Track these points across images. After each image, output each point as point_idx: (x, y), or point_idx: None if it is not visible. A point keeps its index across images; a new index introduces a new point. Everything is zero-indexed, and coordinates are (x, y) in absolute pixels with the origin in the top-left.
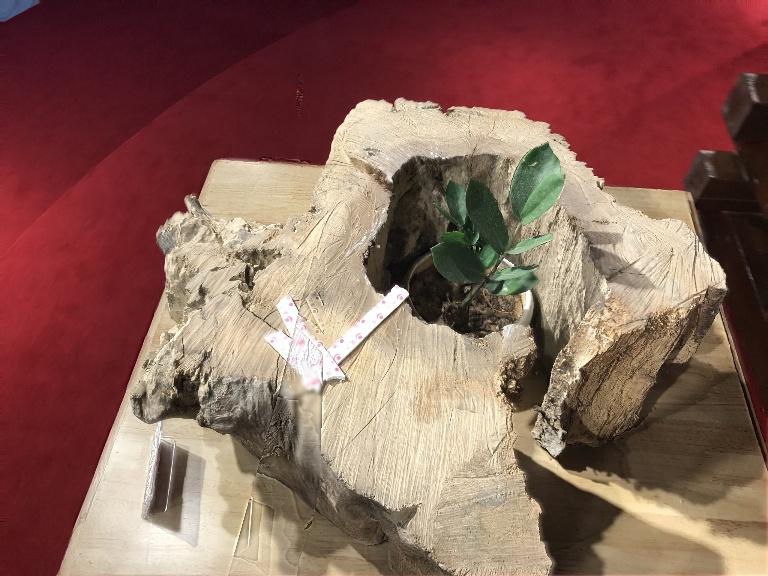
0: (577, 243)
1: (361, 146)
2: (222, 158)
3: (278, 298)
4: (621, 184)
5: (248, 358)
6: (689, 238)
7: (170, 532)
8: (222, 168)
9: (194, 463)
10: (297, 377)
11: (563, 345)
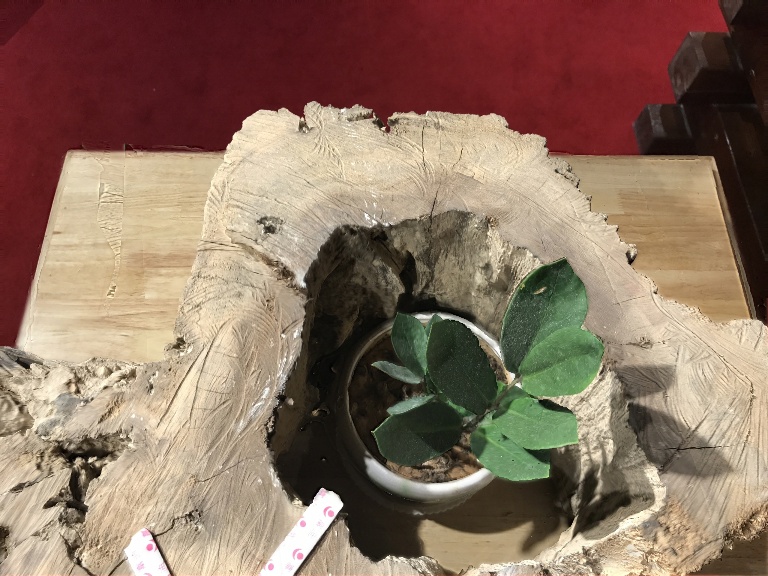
0: (603, 379)
1: (251, 215)
2: (79, 147)
3: (128, 532)
4: (625, 151)
5: None
6: None
7: None
8: (78, 167)
9: None
10: None
11: (569, 459)
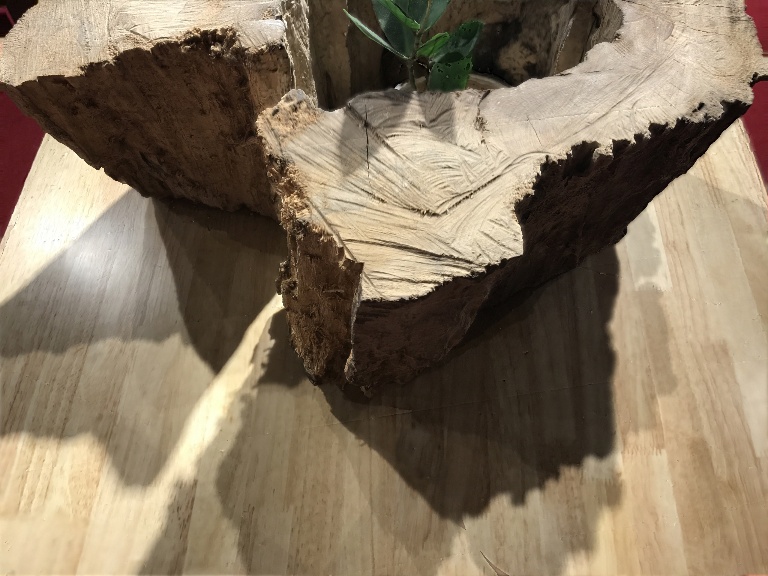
0: None
1: None
2: None
3: None
4: None
5: None
6: (469, 248)
7: None
8: None
9: None
10: None
11: None
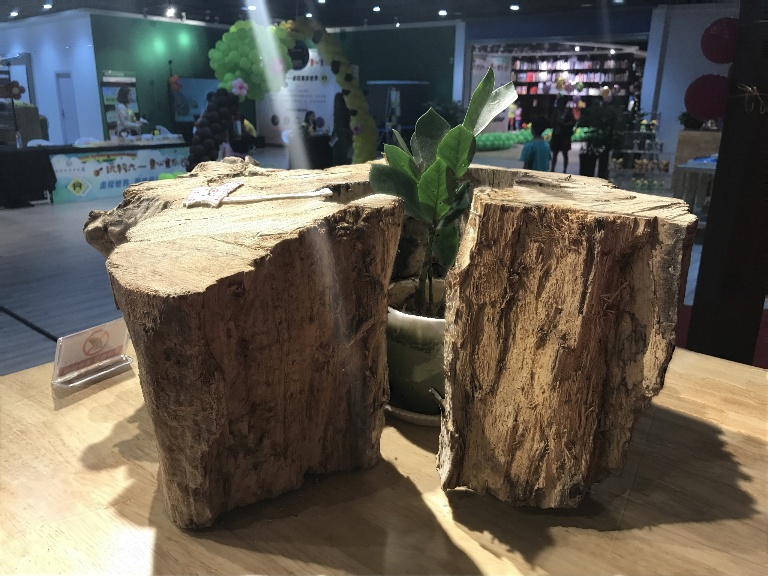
0: None
1: None
2: None
3: None
4: None
5: (172, 193)
6: (670, 199)
7: (54, 396)
8: None
9: (126, 375)
10: (109, 43)
11: None
